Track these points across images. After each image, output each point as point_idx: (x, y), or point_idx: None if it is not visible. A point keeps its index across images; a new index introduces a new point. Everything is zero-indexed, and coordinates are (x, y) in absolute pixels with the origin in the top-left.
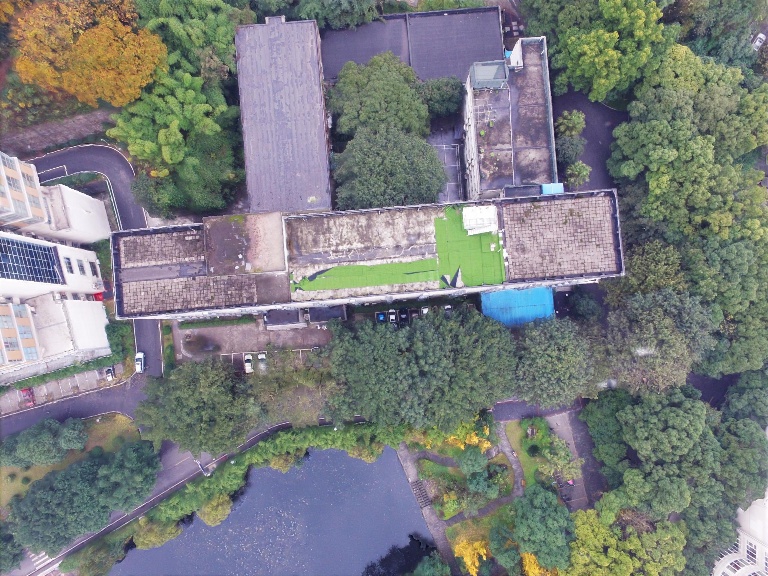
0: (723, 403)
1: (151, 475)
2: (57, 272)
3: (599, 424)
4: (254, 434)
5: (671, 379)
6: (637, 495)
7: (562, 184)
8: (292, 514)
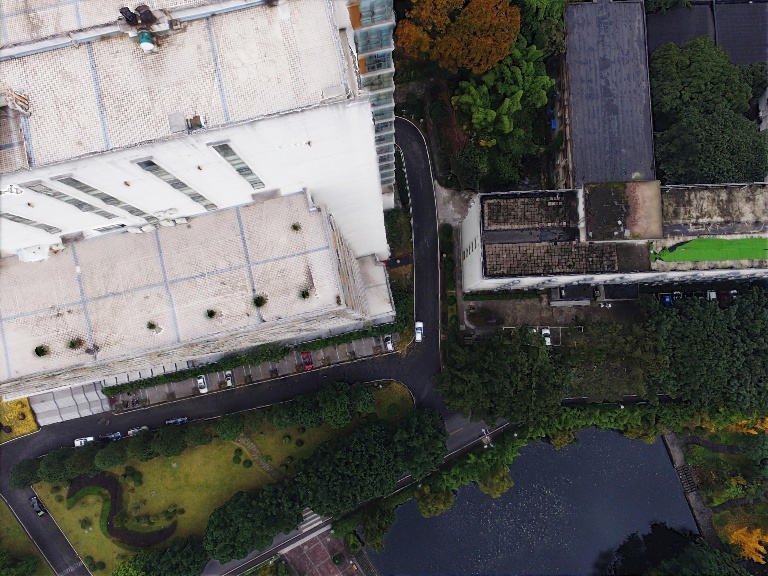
0: None
1: (442, 442)
2: None
3: None
4: None
5: None
6: None
7: None
8: (556, 492)
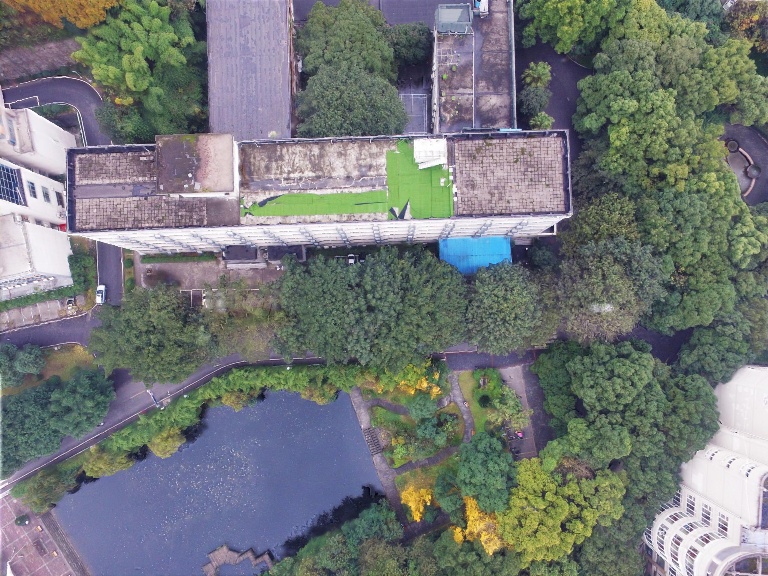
0: (675, 361)
1: (103, 403)
2: (19, 194)
3: (550, 375)
4: (209, 371)
5: (616, 324)
6: (579, 442)
7: None
8: (244, 454)
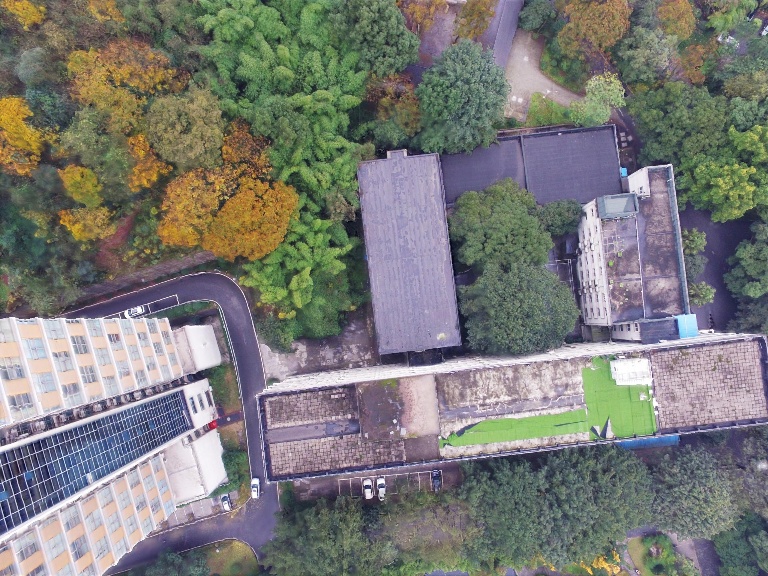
0: None
1: None
2: (185, 416)
3: (729, 546)
4: None
5: None
6: None
7: (695, 315)
8: None
